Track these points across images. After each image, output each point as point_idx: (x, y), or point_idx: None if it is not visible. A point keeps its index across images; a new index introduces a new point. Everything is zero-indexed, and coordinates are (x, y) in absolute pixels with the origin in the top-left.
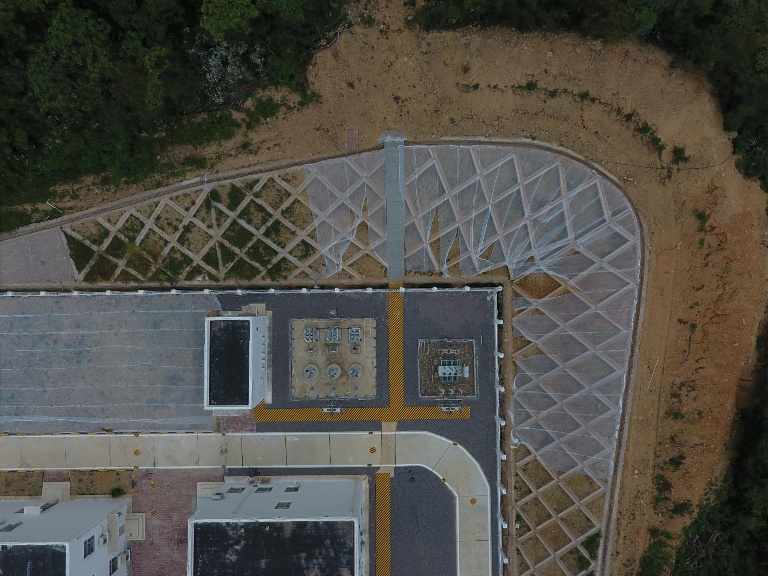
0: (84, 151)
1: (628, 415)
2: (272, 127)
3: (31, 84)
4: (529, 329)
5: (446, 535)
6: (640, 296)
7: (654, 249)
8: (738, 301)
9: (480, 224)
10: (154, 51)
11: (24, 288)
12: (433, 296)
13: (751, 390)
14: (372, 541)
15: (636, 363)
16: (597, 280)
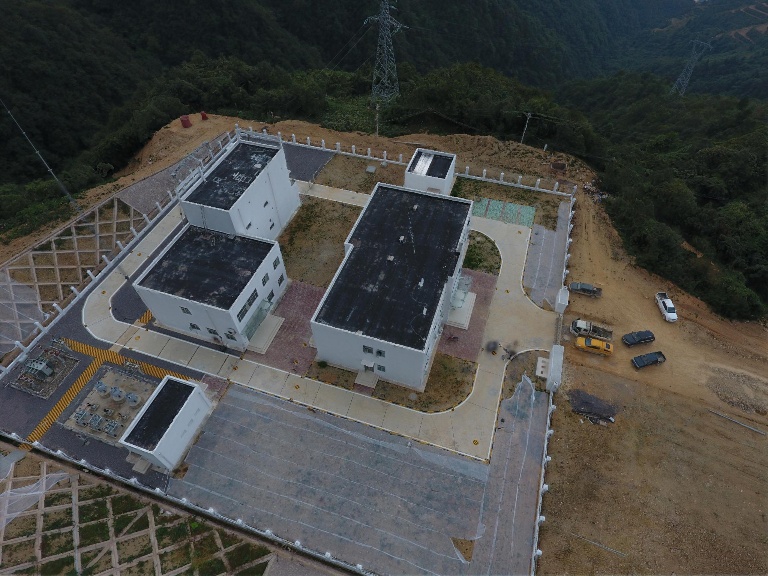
0: None
1: None
2: None
3: None
4: None
5: None
6: None
7: None
8: None
9: None
10: None
11: None
12: (8, 429)
13: None
14: None
15: None
16: None
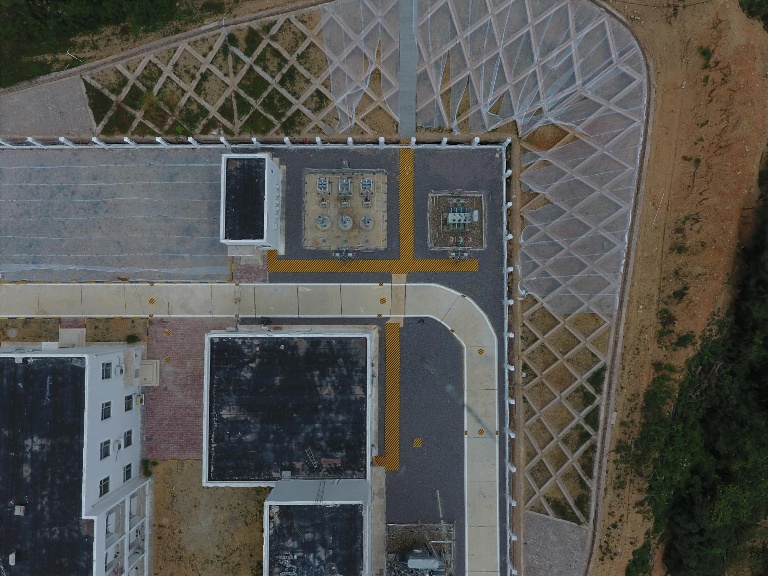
0: None
1: (633, 251)
2: None
3: None
4: (537, 182)
5: (454, 384)
6: (646, 134)
7: (660, 88)
8: (741, 129)
9: (490, 72)
10: None
11: None
12: (443, 153)
13: (753, 217)
14: (381, 389)
15: (641, 200)
16: (604, 123)
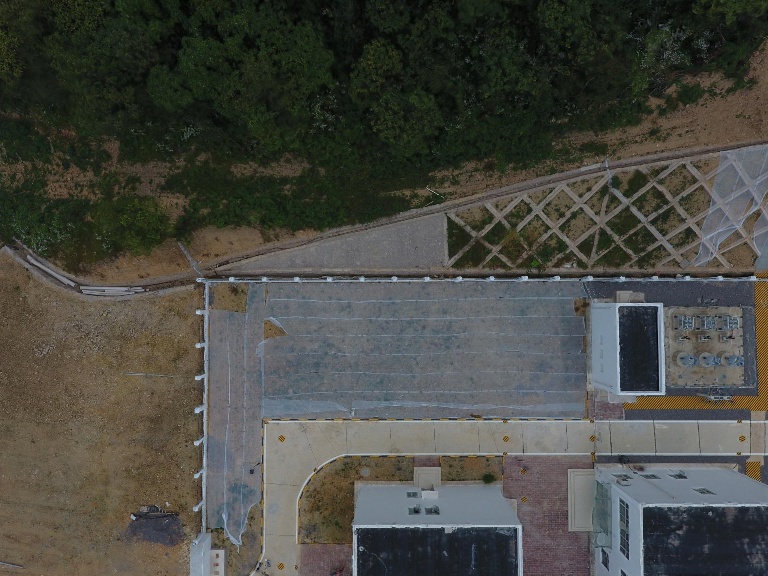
0: (481, 136)
1: None
2: (686, 114)
3: (488, 67)
4: None
5: None
6: None
7: None
8: None
9: None
10: (659, 34)
11: (388, 274)
12: None
13: None
14: None
15: None
16: None
